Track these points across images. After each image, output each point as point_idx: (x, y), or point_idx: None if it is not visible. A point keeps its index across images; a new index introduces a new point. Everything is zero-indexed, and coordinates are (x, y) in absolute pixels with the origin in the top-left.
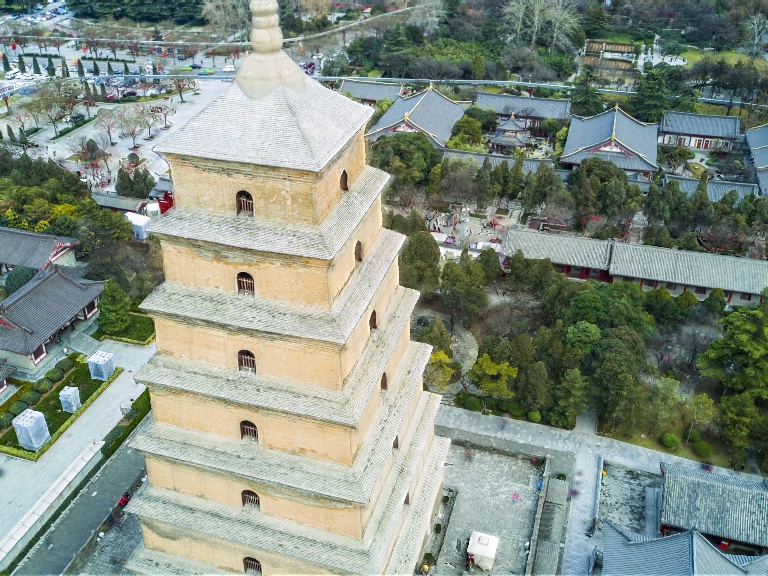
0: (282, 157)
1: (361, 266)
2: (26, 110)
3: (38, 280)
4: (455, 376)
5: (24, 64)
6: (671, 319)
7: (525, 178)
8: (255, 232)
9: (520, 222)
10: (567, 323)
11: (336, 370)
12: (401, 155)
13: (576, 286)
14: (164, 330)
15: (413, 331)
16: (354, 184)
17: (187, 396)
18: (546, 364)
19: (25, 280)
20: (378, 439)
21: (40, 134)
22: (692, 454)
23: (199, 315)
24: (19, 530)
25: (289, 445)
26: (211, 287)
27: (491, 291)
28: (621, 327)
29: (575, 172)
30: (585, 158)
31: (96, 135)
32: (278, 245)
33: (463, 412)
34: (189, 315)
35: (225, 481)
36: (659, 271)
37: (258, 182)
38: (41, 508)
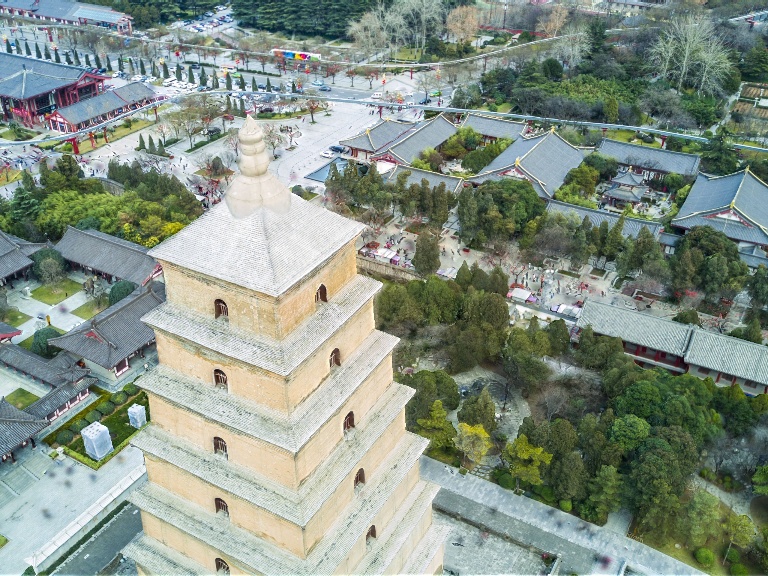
0: (249, 278)
1: (338, 371)
2: (172, 119)
3: (135, 296)
4: (498, 447)
5: (182, 72)
6: (741, 421)
7: (624, 241)
8: (228, 337)
9: (613, 286)
10: (620, 412)
11: (291, 472)
12: (502, 203)
13: (635, 375)
14: (156, 405)
15: (467, 394)
16: (337, 295)
17: (173, 466)
18: (586, 453)
19: (125, 294)
20: (342, 533)
21: (178, 145)
22: (727, 575)
23: (180, 401)
24: (62, 537)
25: (254, 528)
26: (194, 376)
27: (554, 363)
28: (673, 427)
29: (683, 239)
30: (695, 225)
31: (223, 153)
32: (244, 354)
33: (495, 488)
34: (172, 399)
35: (202, 546)
36: (739, 366)
37: (231, 295)
38: (85, 519)
